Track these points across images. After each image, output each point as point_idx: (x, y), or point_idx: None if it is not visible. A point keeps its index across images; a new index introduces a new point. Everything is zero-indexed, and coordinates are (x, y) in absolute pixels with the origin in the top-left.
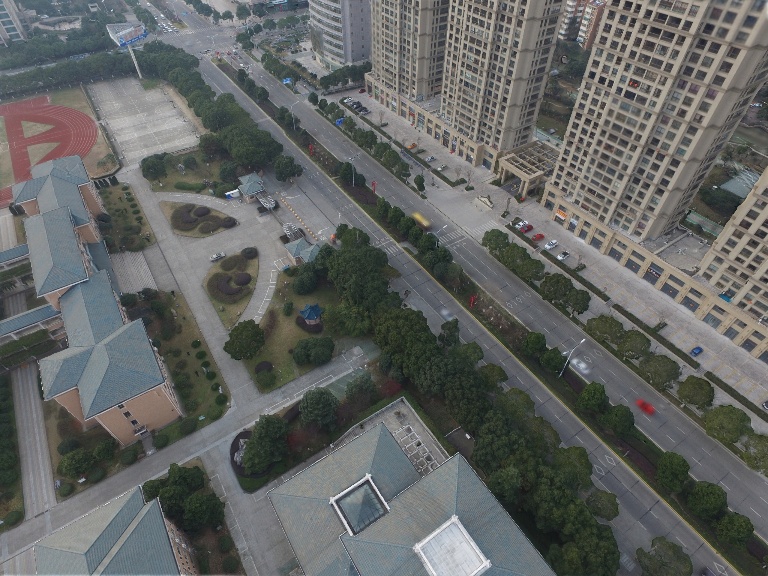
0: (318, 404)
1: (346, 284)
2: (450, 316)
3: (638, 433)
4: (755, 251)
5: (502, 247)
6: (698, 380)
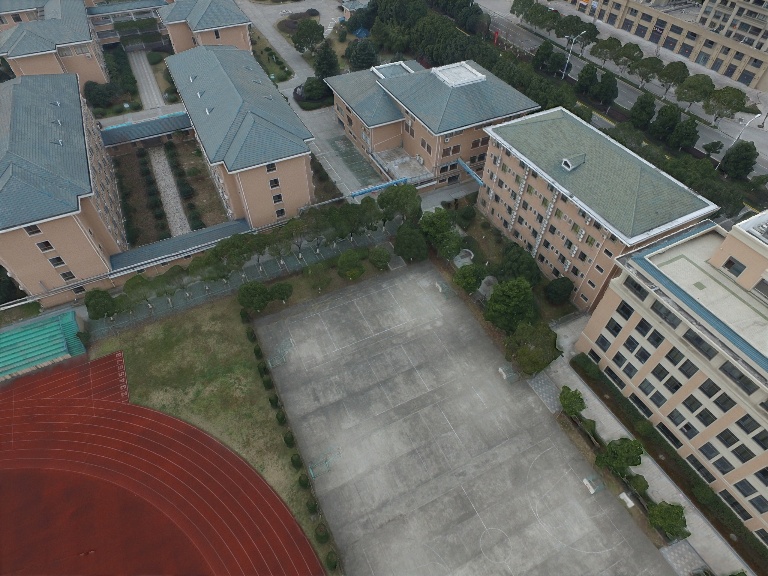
0: (365, 51)
1: (393, 7)
2: None
3: (621, 106)
4: None
5: (527, 11)
6: None
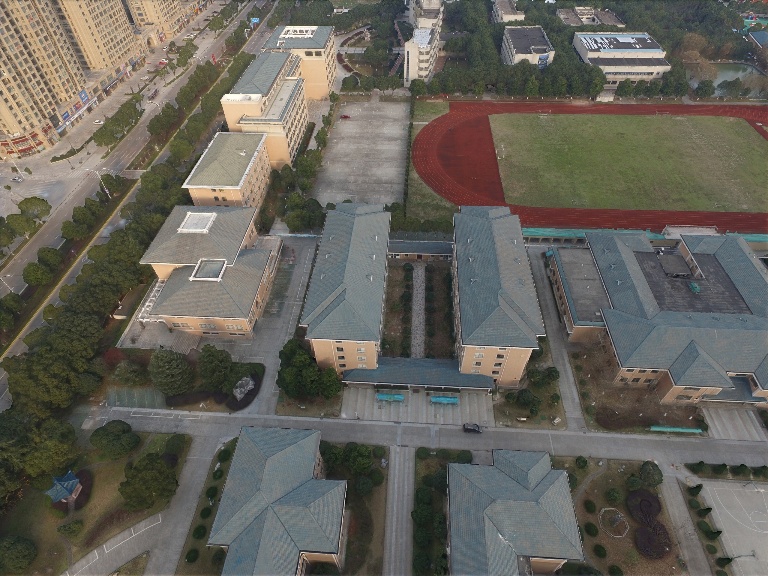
0: None
1: (1, 458)
2: None
3: None
4: None
5: None
6: None
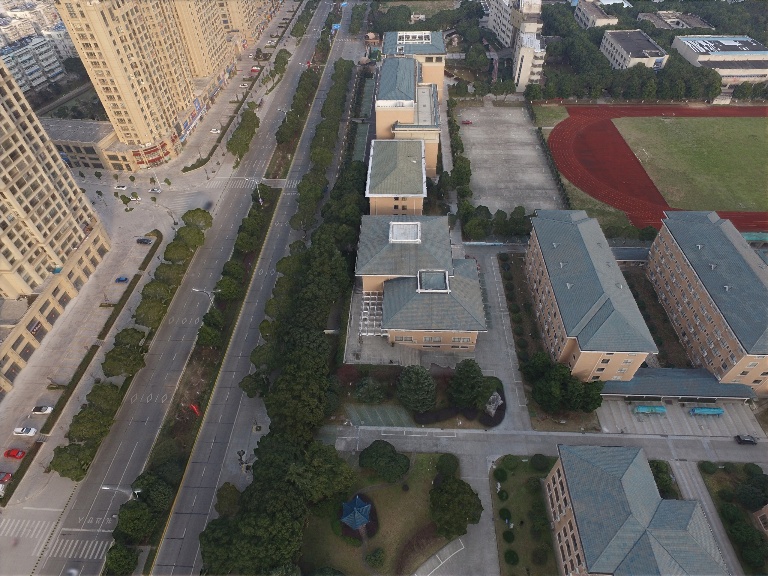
0: None
1: (301, 485)
2: (224, 424)
3: None
4: (18, 236)
5: None
6: (171, 247)
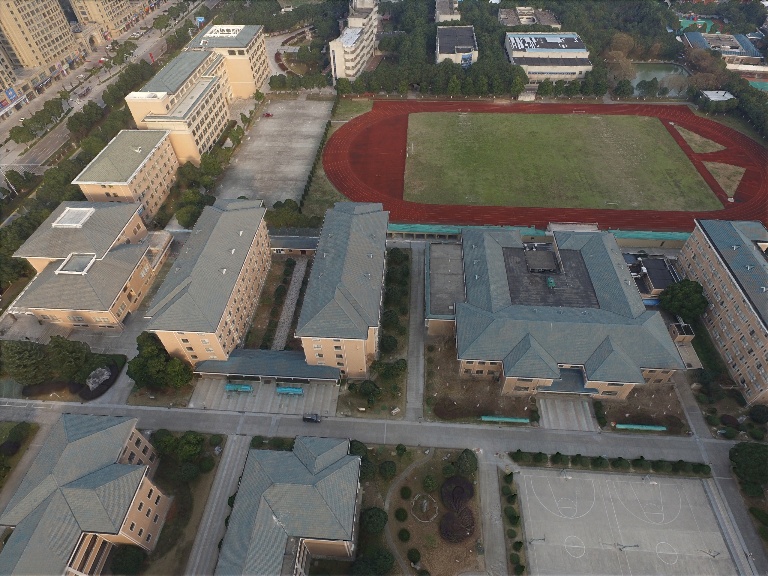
0: (20, 343)
1: None
2: None
3: None
4: None
5: None
6: None
